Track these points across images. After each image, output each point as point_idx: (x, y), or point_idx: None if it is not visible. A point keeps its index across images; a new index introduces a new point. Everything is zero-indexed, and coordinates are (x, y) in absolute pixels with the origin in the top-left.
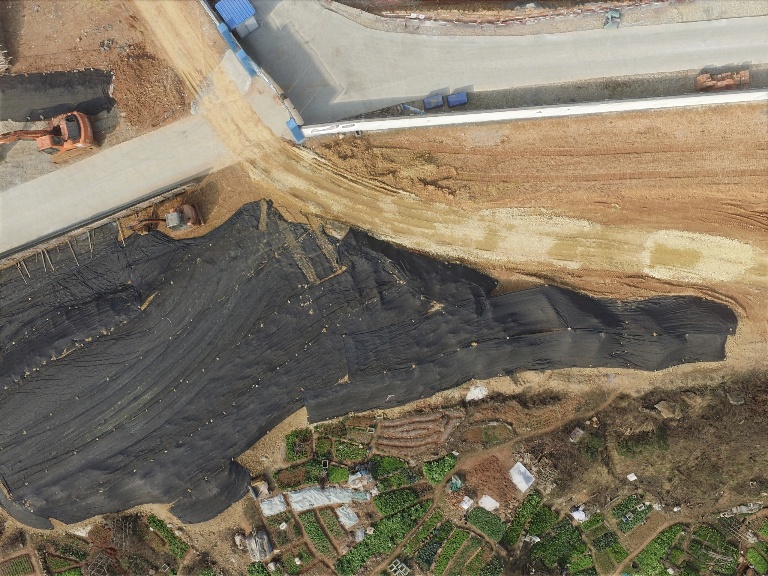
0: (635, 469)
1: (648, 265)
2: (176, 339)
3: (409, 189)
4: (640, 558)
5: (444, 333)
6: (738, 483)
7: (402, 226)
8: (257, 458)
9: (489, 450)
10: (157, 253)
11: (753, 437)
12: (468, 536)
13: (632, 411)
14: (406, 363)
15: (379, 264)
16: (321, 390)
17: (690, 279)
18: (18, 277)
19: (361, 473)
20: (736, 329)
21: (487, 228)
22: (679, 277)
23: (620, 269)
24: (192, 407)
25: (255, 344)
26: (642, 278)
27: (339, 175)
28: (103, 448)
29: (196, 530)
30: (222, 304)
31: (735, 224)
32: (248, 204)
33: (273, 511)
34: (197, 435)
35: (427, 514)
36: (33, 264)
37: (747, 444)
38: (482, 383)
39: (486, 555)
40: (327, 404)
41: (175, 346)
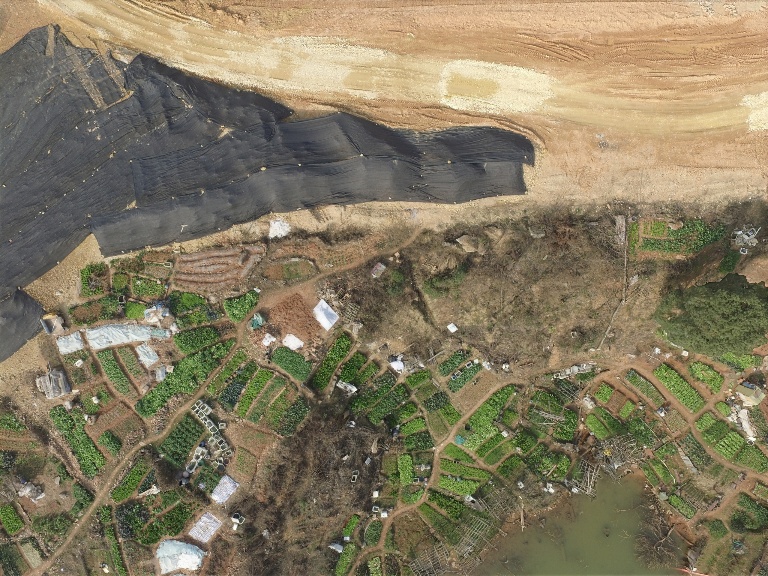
0: (454, 318)
1: (445, 95)
2: None
3: (199, 15)
4: (472, 420)
5: (234, 159)
6: (561, 335)
7: (194, 54)
8: (51, 292)
9: (292, 288)
10: None
11: (559, 274)
12: (272, 376)
13: (436, 247)
14: (194, 188)
15: (167, 89)
16: (108, 216)
17: (488, 110)
18: None
19: (156, 307)
20: (534, 160)
21: (281, 56)
22: (477, 108)
23: (417, 100)
24: None
25: (42, 171)
26: (439, 108)
27: (129, 1)
28: None
29: None
30: (9, 131)
31: (531, 54)
32: (35, 29)
33: (70, 349)
34: None
35: (231, 354)
36: None
37: (555, 283)
38: (281, 217)
39: (291, 395)
40: (117, 232)
41: None
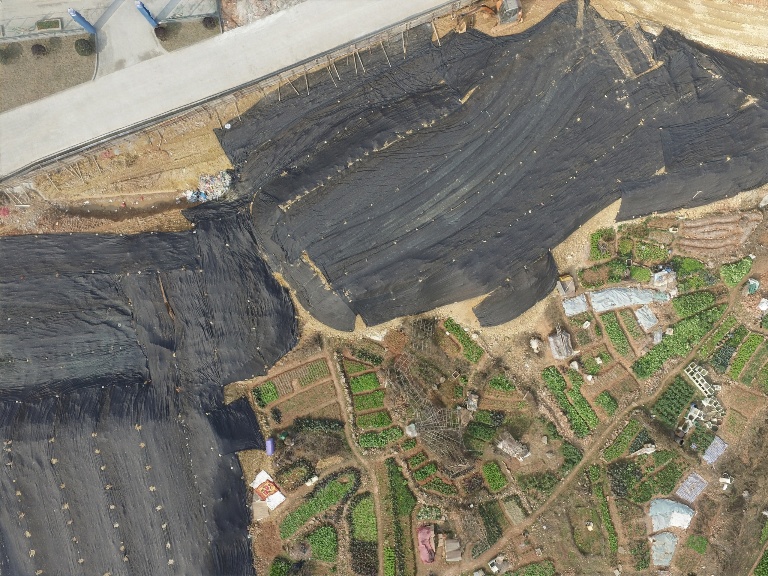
0: None
1: None
2: (494, 132)
3: None
4: None
5: (756, 128)
6: None
7: (711, 27)
8: (564, 255)
9: None
10: (474, 51)
11: None
12: (762, 340)
13: None
14: (721, 155)
15: (694, 60)
16: (638, 181)
17: None
18: (328, 80)
19: (667, 270)
20: None
21: None
22: None
23: None
24: (510, 199)
25: (572, 137)
26: None
27: None
28: (422, 239)
29: (491, 334)
30: (539, 99)
31: None
32: (565, 2)
33: (576, 310)
34: (515, 225)
35: (722, 318)
36: (344, 67)
37: None
38: None
39: None
40: (641, 197)
41: (493, 139)
